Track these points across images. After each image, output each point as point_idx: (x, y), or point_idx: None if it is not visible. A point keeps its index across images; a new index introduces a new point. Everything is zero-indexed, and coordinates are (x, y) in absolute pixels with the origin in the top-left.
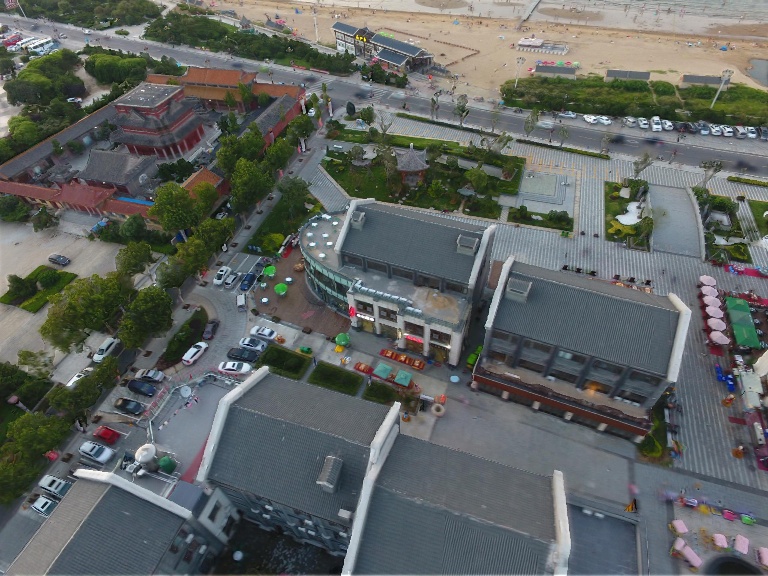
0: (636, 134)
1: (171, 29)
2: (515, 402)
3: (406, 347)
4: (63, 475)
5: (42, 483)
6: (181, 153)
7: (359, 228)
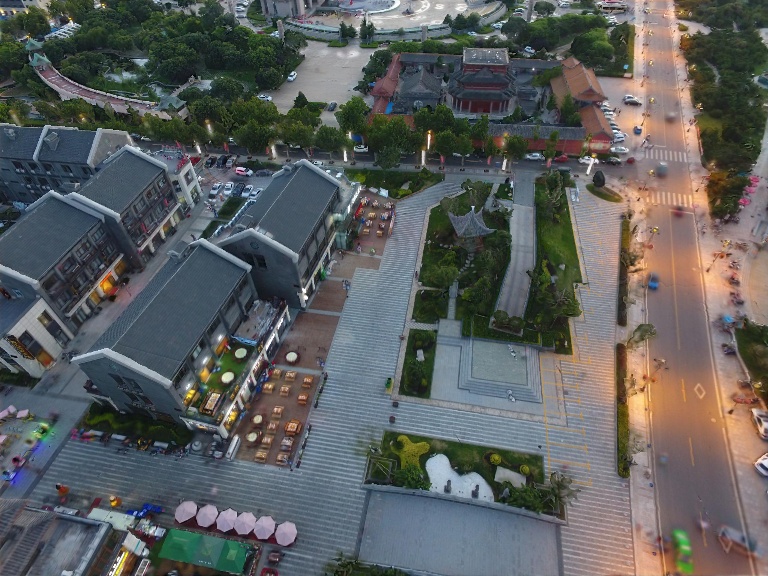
0: (763, 553)
1: (704, 41)
2: None
3: None
4: None
5: None
6: (461, 109)
7: None
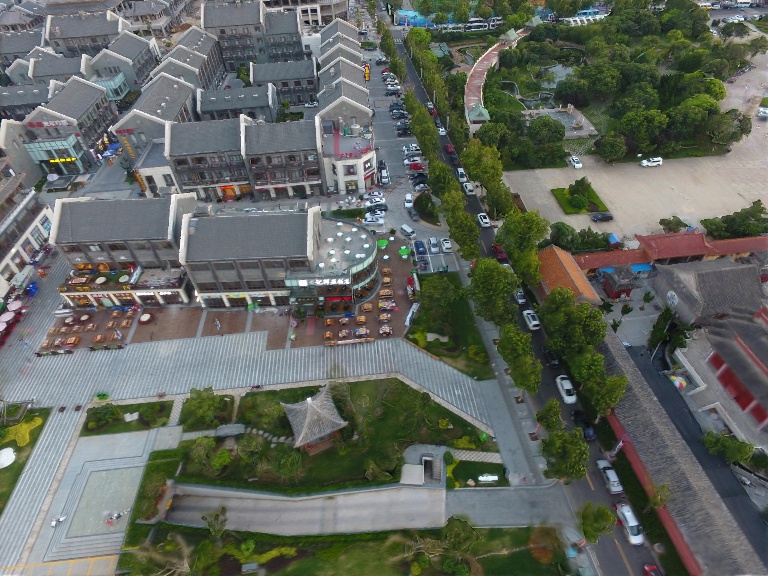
0: None
1: None
2: None
3: None
4: (420, 156)
5: None
6: None
7: None
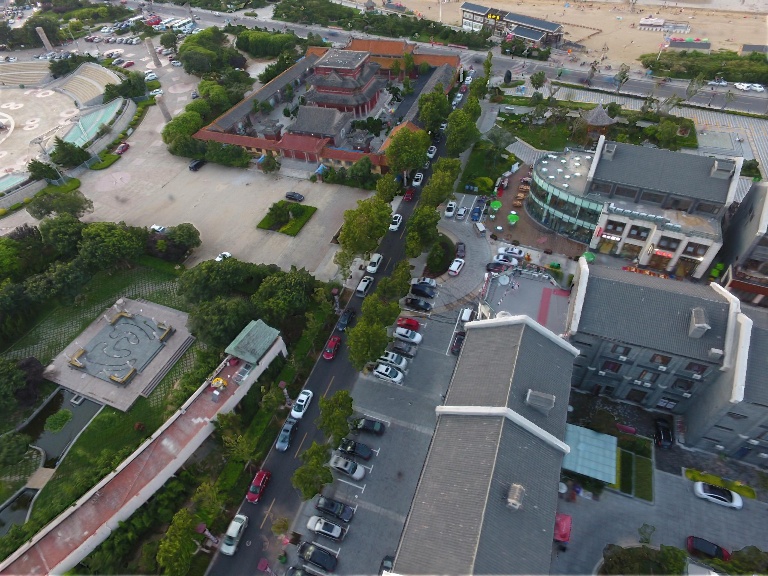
0: None
1: (302, 10)
2: (764, 307)
3: (649, 263)
4: None
5: None
6: (366, 112)
7: (609, 159)
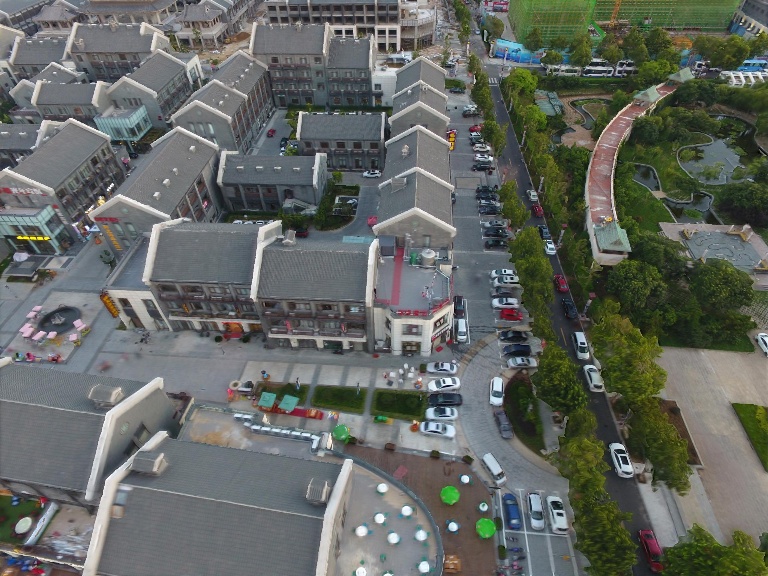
0: None
1: None
2: None
3: None
4: (516, 291)
5: None
6: None
7: None
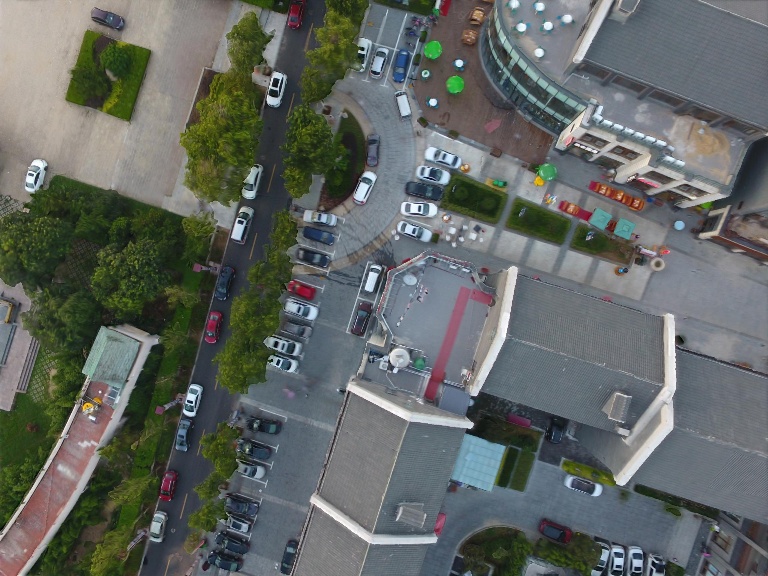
0: None
1: None
2: (743, 254)
3: (627, 183)
4: (276, 330)
5: (266, 344)
6: None
7: (621, 20)
